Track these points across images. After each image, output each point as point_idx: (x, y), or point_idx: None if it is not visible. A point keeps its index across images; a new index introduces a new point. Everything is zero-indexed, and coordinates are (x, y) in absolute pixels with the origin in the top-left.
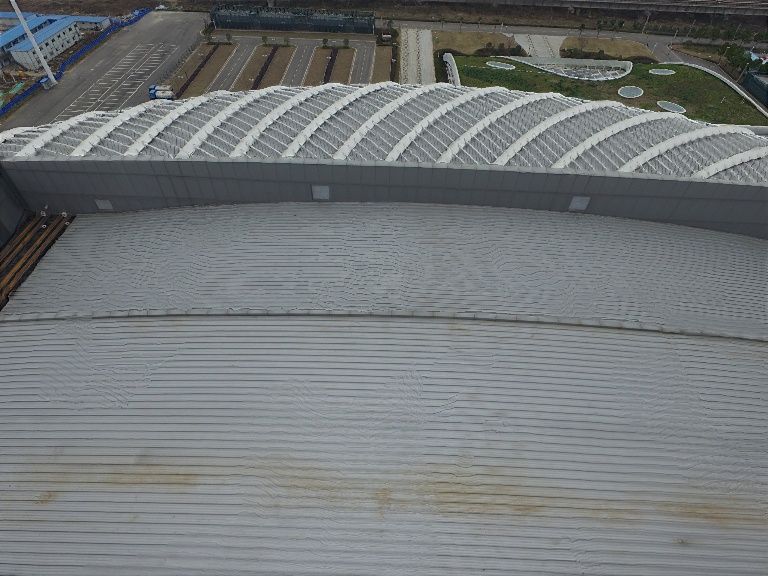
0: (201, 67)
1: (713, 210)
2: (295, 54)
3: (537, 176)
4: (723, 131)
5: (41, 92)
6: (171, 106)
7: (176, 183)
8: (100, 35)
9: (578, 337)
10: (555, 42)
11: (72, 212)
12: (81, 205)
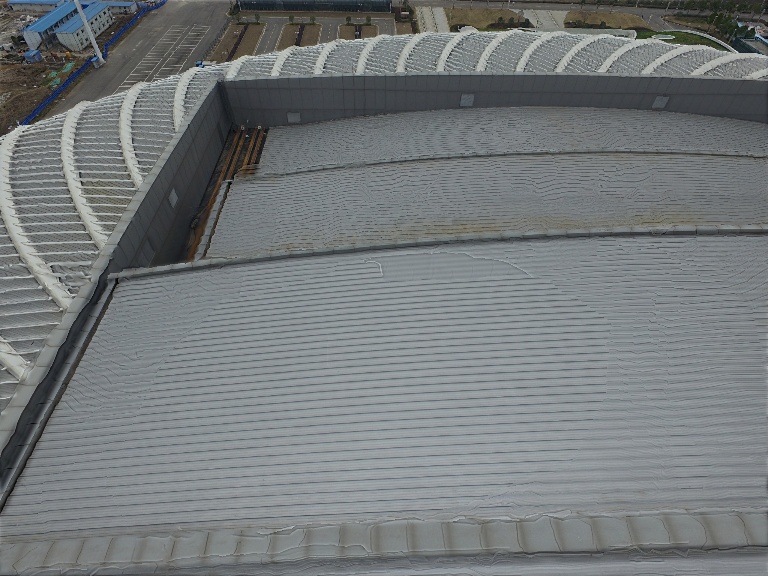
0: (237, 45)
1: (758, 104)
2: (322, 31)
3: (633, 80)
4: (752, 56)
5: (92, 70)
6: (315, 48)
7: (358, 95)
8: (133, 18)
9: (700, 160)
10: (559, 16)
11: (266, 125)
12: (275, 119)
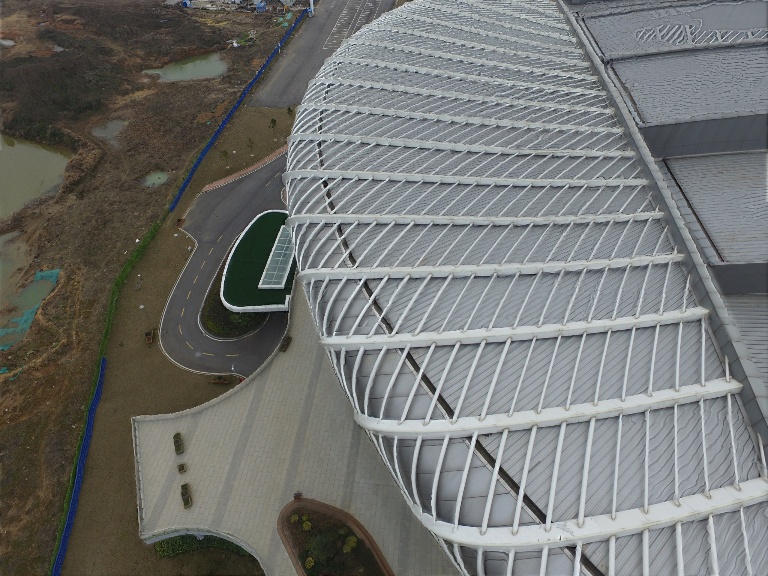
0: None
1: None
2: None
3: None
4: None
5: (308, 19)
6: None
7: None
8: None
9: None
10: None
11: None
12: None
